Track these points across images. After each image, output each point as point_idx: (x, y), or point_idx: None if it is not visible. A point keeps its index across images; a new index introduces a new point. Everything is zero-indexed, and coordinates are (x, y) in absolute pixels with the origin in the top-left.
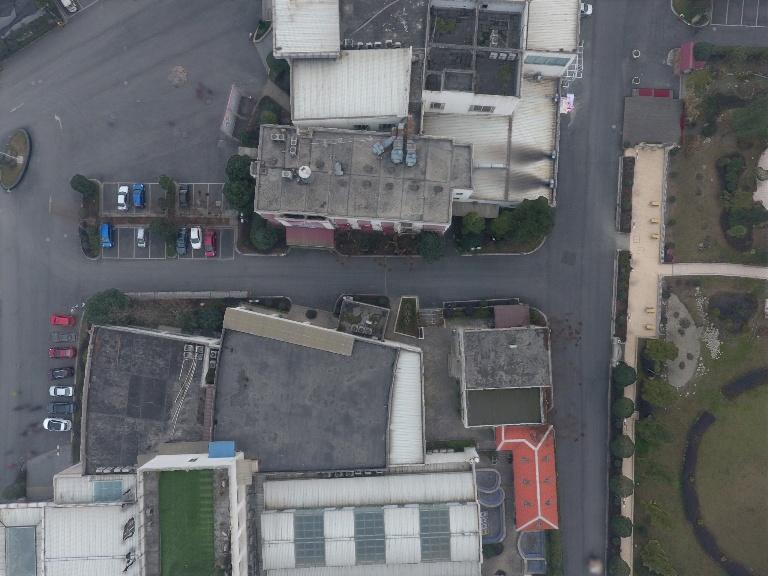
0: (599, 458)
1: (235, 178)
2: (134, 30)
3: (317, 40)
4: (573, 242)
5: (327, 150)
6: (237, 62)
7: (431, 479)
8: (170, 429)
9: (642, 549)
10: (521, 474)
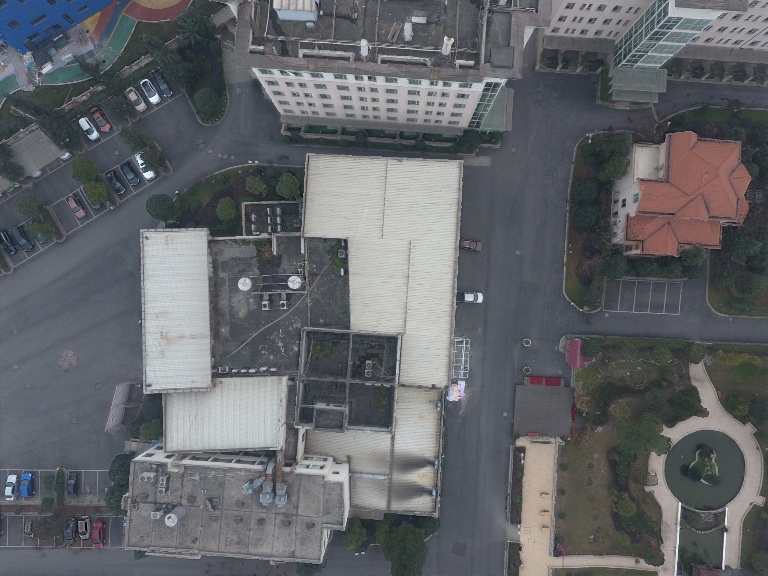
0: None
1: (118, 483)
2: (24, 313)
3: (188, 376)
4: (463, 532)
5: (199, 484)
6: (127, 347)
7: None
8: None
9: None
10: None
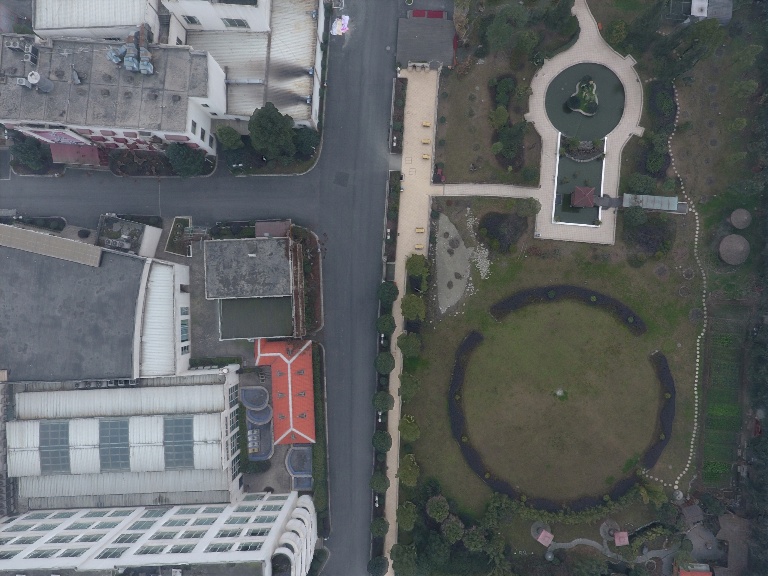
0: (368, 377)
1: None
2: None
3: None
4: (346, 163)
5: (67, 59)
6: None
7: (183, 391)
8: None
9: None
10: (277, 388)
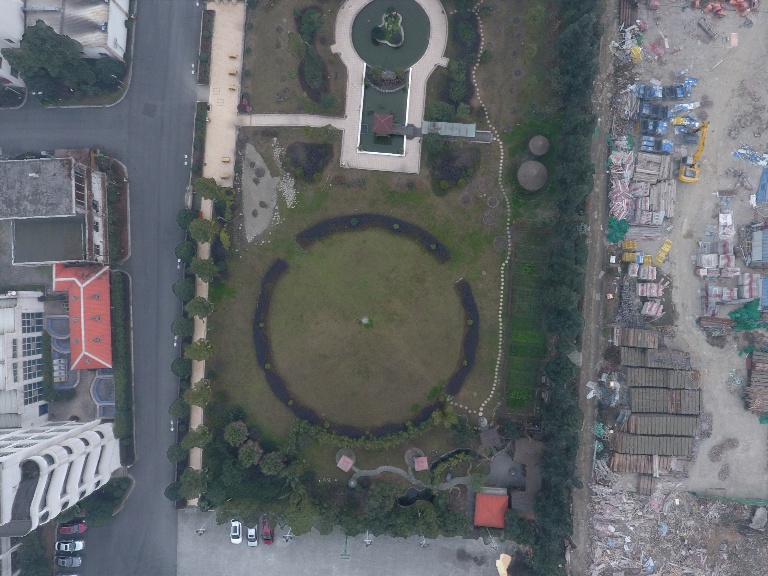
0: (174, 305)
1: None
2: None
3: None
4: (155, 94)
5: None
6: None
7: None
8: None
9: (213, 394)
10: (73, 313)
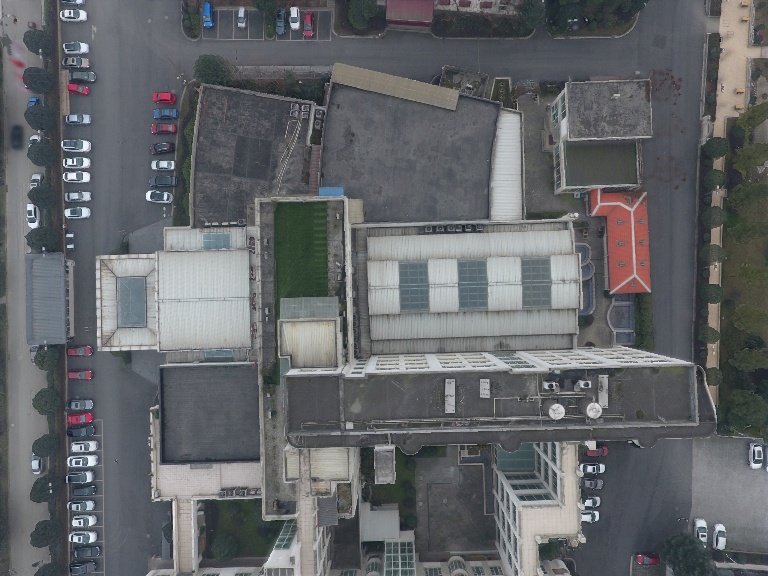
0: (687, 234)
1: None
2: None
3: None
4: (663, 26)
5: None
6: None
7: (530, 236)
8: (275, 188)
9: (729, 322)
10: (616, 237)
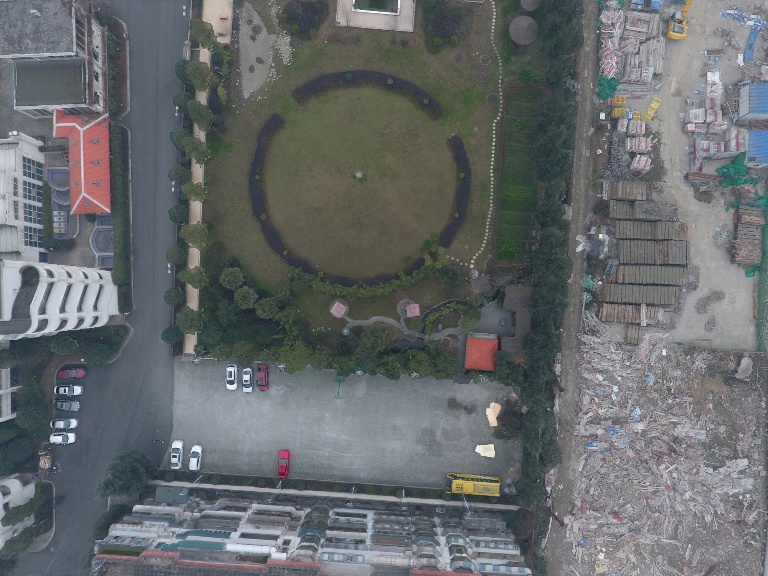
0: (172, 159)
1: None
2: None
3: None
4: None
5: None
6: None
7: None
8: None
9: None
10: (73, 157)
